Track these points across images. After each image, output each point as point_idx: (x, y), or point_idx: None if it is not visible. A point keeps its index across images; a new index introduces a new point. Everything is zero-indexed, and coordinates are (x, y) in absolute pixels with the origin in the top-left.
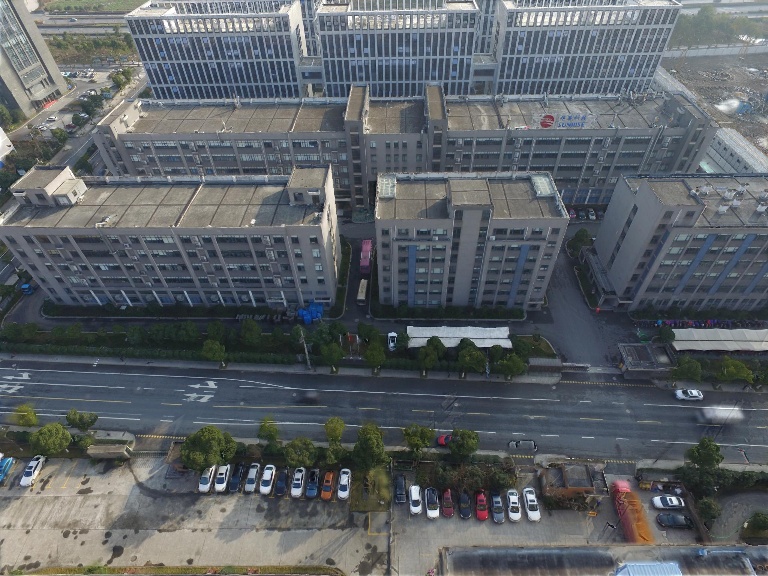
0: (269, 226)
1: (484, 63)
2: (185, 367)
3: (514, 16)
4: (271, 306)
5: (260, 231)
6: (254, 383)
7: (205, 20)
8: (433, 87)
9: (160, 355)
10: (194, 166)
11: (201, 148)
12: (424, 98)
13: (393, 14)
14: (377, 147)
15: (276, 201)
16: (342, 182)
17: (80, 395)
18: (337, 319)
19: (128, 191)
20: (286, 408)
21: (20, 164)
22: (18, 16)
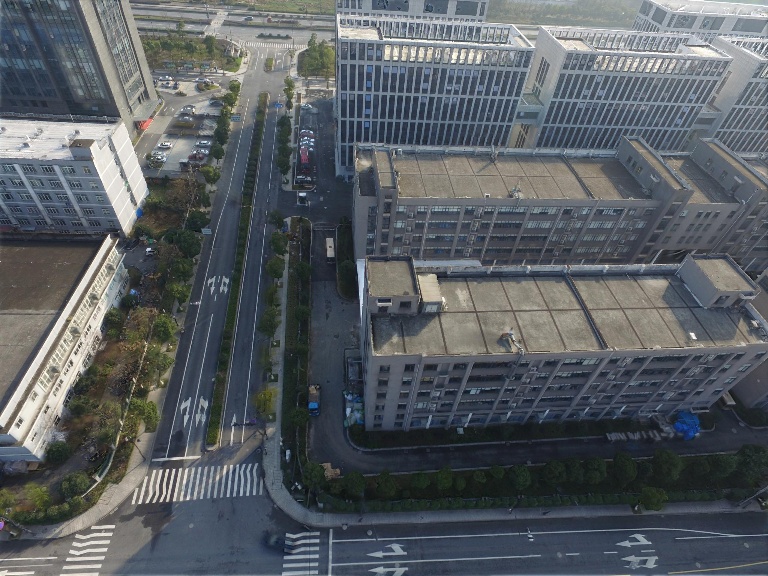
0: (711, 341)
1: (707, 111)
2: (592, 516)
3: (764, 67)
4: (634, 418)
5: (714, 350)
6: (689, 532)
7: (436, 48)
8: (709, 144)
9: (564, 504)
10: (466, 233)
11: (487, 214)
12: (690, 154)
13: (647, 57)
14: (686, 216)
15: (681, 302)
16: (620, 250)
17: (493, 574)
18: (713, 431)
19: (487, 287)
20: (752, 567)
21: (197, 219)
22: (123, 14)
